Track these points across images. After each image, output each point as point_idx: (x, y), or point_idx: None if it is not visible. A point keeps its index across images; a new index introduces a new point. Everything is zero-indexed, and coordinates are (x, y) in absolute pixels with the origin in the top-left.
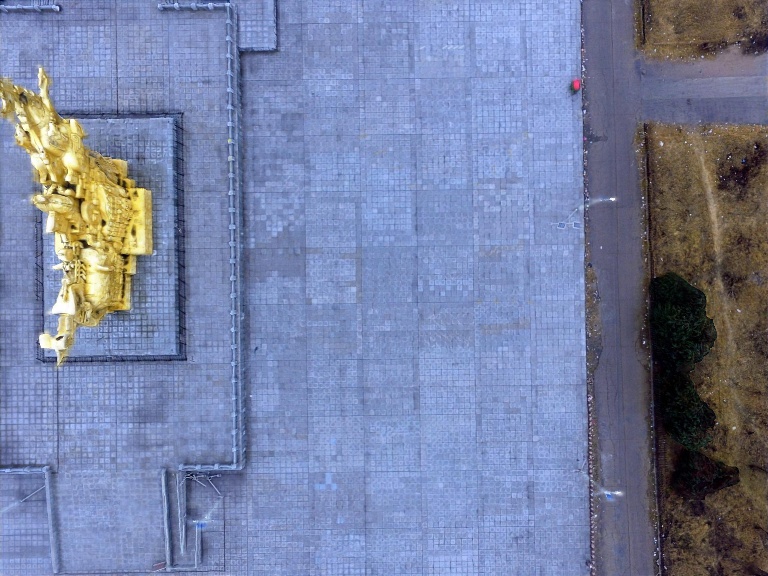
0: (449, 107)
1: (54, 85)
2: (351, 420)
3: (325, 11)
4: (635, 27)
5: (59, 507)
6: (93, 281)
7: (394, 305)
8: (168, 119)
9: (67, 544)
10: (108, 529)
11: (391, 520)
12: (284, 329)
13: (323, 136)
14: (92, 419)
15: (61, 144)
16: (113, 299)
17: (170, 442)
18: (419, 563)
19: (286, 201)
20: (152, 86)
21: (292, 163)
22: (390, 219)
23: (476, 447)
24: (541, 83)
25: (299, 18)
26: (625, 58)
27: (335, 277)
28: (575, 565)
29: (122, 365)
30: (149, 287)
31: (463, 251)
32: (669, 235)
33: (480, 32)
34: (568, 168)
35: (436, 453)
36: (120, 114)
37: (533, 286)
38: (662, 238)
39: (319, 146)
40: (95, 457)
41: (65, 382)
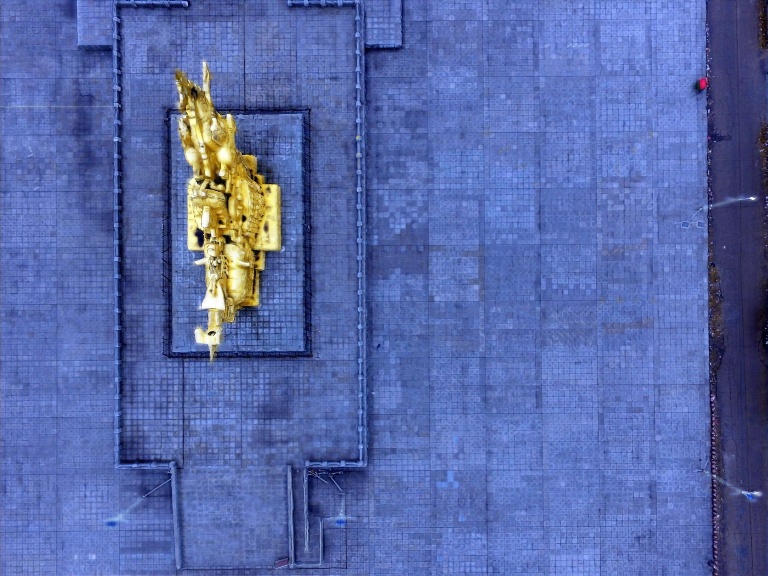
0: (573, 105)
1: None
2: (473, 418)
3: (450, 8)
4: (760, 26)
5: (183, 503)
6: (235, 276)
7: (517, 303)
8: (297, 115)
9: (190, 540)
10: (231, 525)
11: (513, 518)
12: (407, 326)
13: (447, 133)
14: (217, 415)
15: (221, 139)
16: (247, 295)
17: (295, 438)
18: (541, 562)
19: (409, 198)
20: (279, 82)
21: (416, 160)
22: (513, 217)
23: (598, 446)
24: (666, 82)
25: (424, 15)
26: (750, 57)
27: (458, 275)
28: (697, 565)
29: (247, 361)
30: (277, 283)
31: (586, 250)
32: None
33: (605, 30)
34: (692, 167)
35: (558, 452)
36: (247, 110)
37: (656, 285)
38: None
39: (443, 143)
40: (220, 453)
41: (191, 378)
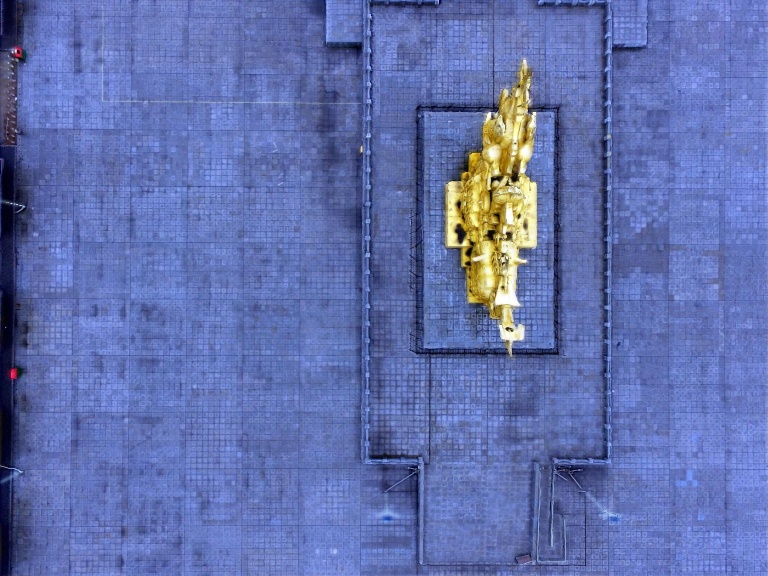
0: None
1: (431, 78)
2: (712, 417)
3: (693, 8)
4: None
5: (428, 498)
6: (512, 273)
7: (757, 303)
8: (550, 113)
9: (432, 535)
10: (474, 521)
11: (752, 517)
12: (646, 325)
13: (688, 133)
14: (464, 411)
15: None
16: None
17: (541, 435)
18: None
19: (650, 197)
20: None
21: (657, 159)
22: (754, 217)
23: None
24: None
25: (667, 15)
26: None
27: (698, 274)
28: None
29: (494, 358)
30: (528, 280)
31: None
32: None
33: None
34: None
35: None
36: (496, 108)
37: None
38: None
39: (684, 143)
40: (466, 449)
41: (437, 374)
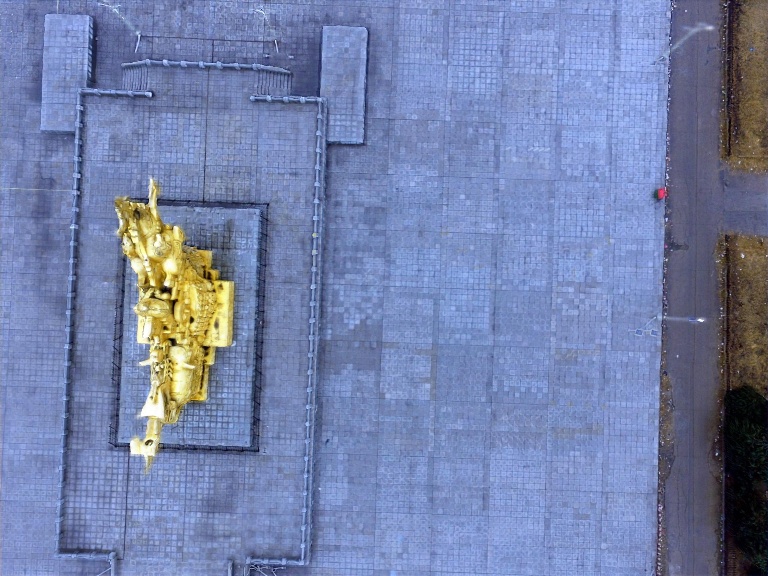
0: (532, 209)
1: (142, 170)
2: (419, 518)
3: (413, 107)
4: (720, 138)
5: None
6: (179, 379)
7: (468, 404)
8: (255, 210)
9: None
10: None
11: None
12: (356, 422)
13: (405, 231)
14: (161, 506)
15: (165, 253)
16: (193, 392)
17: (238, 533)
18: None
19: (365, 294)
20: (239, 175)
21: (373, 257)
22: (468, 317)
23: (544, 552)
24: (625, 189)
25: (387, 113)
26: (709, 168)
27: (410, 373)
28: None
29: (194, 453)
30: (226, 377)
31: (539, 353)
32: (746, 348)
33: (566, 136)
34: (648, 275)
35: (503, 556)
36: (206, 202)
37: (608, 392)
38: (739, 350)
39: (400, 241)
40: (162, 545)
41: (136, 467)
